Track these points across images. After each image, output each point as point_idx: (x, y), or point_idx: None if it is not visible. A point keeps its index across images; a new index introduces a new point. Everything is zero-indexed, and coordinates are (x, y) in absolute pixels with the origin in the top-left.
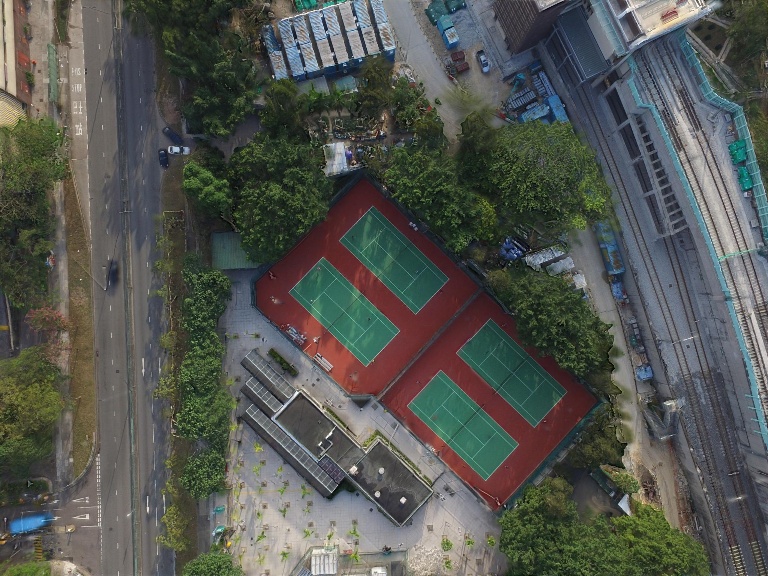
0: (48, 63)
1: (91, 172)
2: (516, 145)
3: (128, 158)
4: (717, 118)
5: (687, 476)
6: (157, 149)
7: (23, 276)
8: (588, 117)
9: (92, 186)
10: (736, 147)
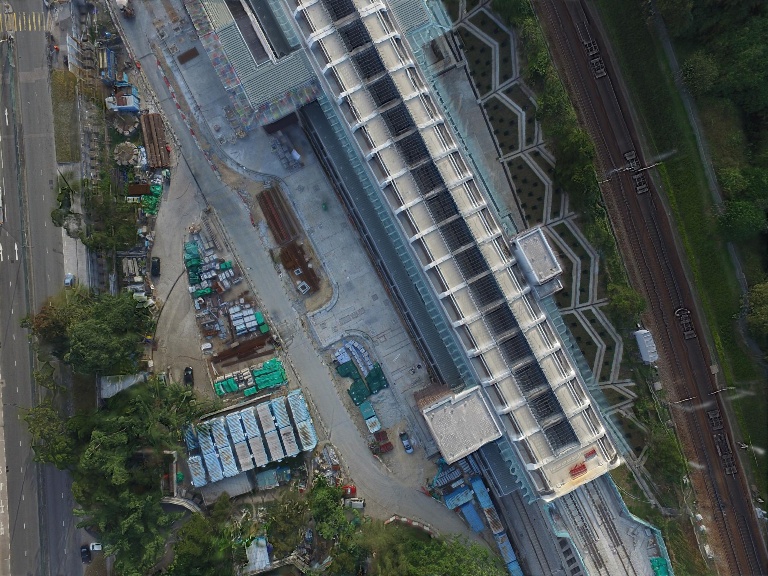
0: None
1: (13, 572)
2: None
3: (50, 555)
4: (637, 532)
5: None
6: (79, 545)
7: None
8: (513, 501)
9: None
10: (657, 563)
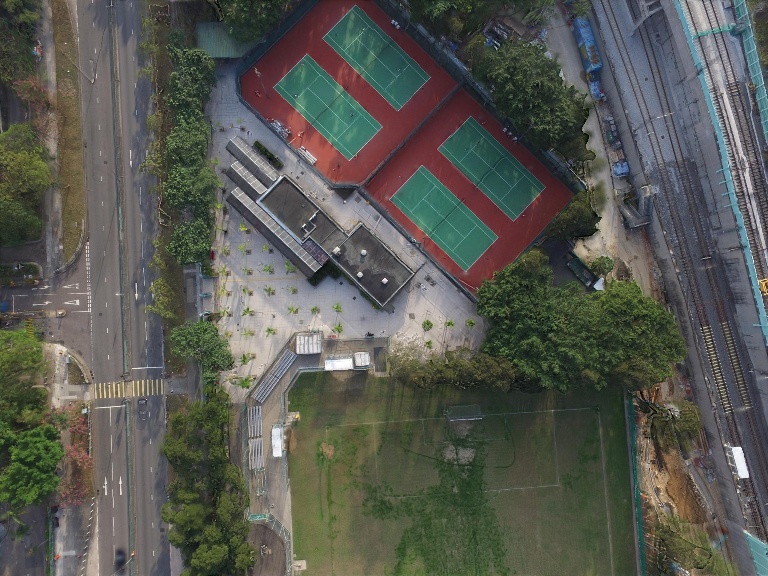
0: None
1: None
2: None
3: None
4: None
5: (661, 266)
6: None
7: (11, 48)
8: None
9: None
10: None
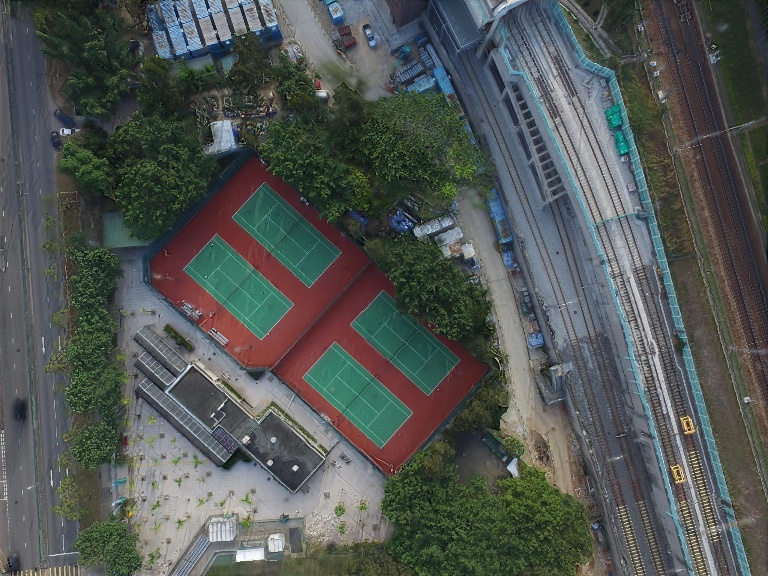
0: None
1: None
2: (386, 115)
3: (22, 141)
4: (592, 83)
5: (578, 440)
6: (50, 132)
7: None
8: (474, 87)
9: None
10: (611, 112)
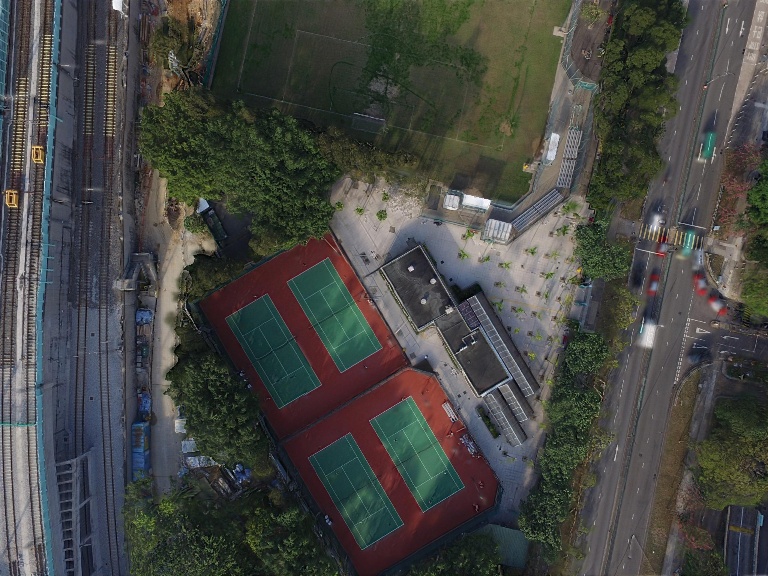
0: None
1: None
2: None
3: None
4: None
5: (133, 208)
6: None
7: None
8: None
9: None
10: None
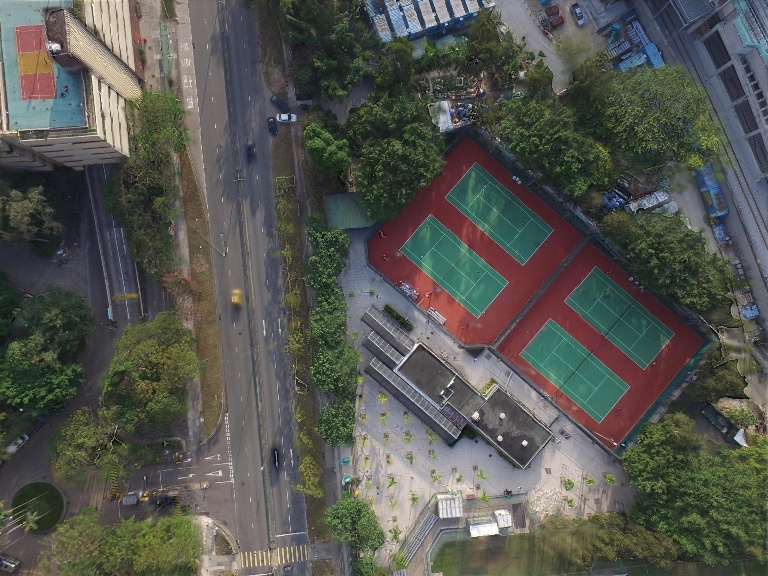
0: (160, 39)
1: (204, 143)
2: (629, 89)
3: (238, 128)
4: None
5: None
6: (265, 118)
7: (156, 242)
8: (685, 63)
9: (206, 157)
10: None
